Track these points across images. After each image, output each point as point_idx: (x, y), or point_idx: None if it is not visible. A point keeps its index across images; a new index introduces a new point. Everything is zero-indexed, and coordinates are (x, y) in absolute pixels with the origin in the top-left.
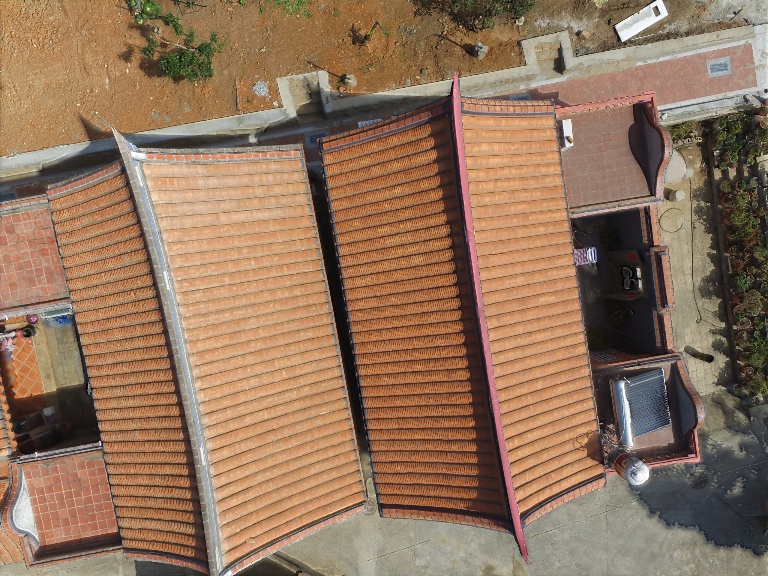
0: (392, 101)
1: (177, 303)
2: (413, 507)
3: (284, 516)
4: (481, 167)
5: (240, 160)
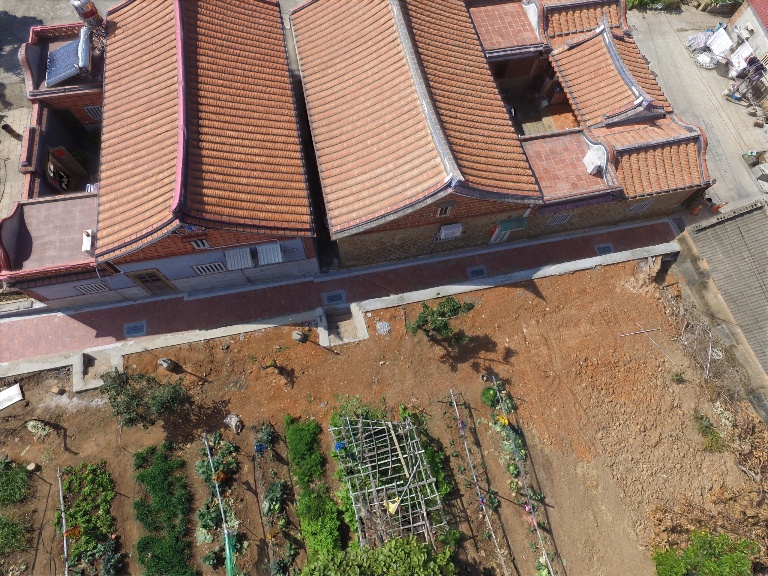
0: None
1: (419, 99)
2: None
3: None
4: None
5: None
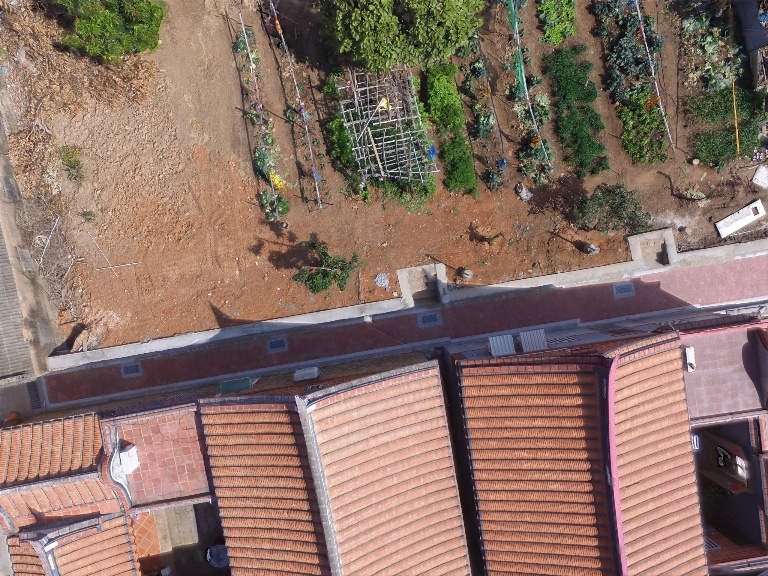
0: (505, 291)
1: (334, 532)
2: None
3: None
4: (620, 409)
5: (386, 386)
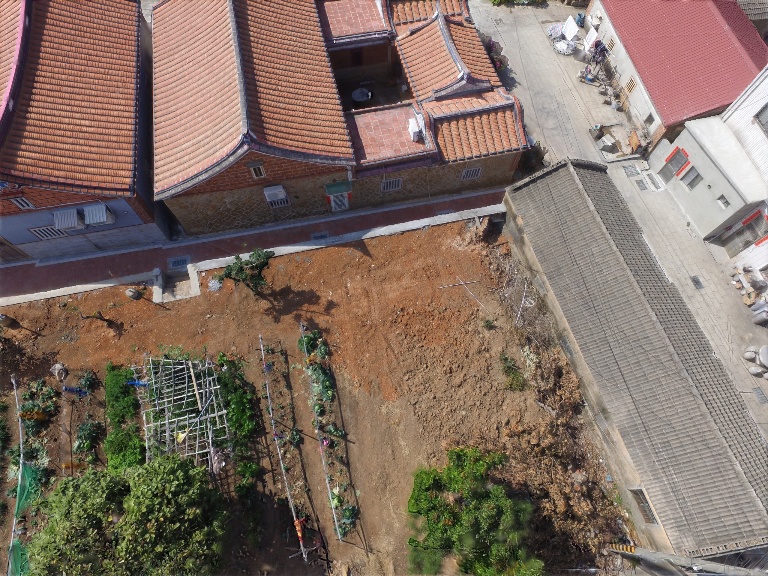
0: None
1: None
2: None
3: None
4: None
5: None
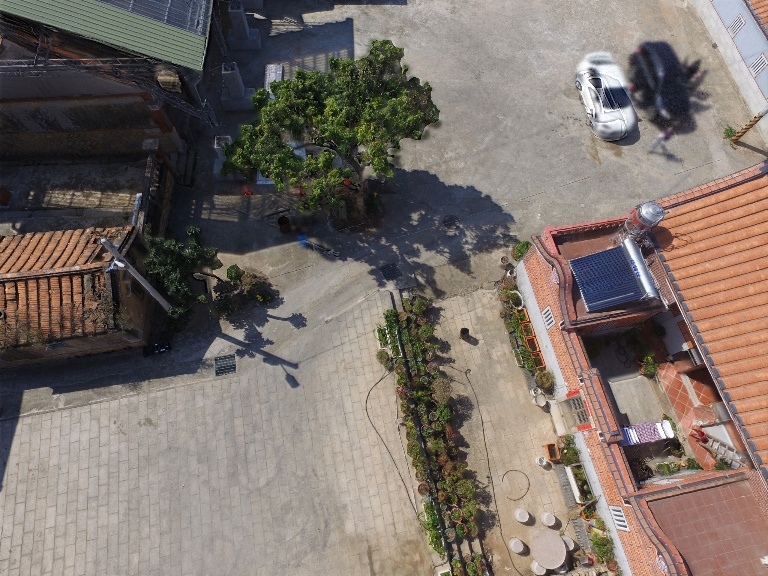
0: None
1: None
2: None
3: None
4: None
5: None
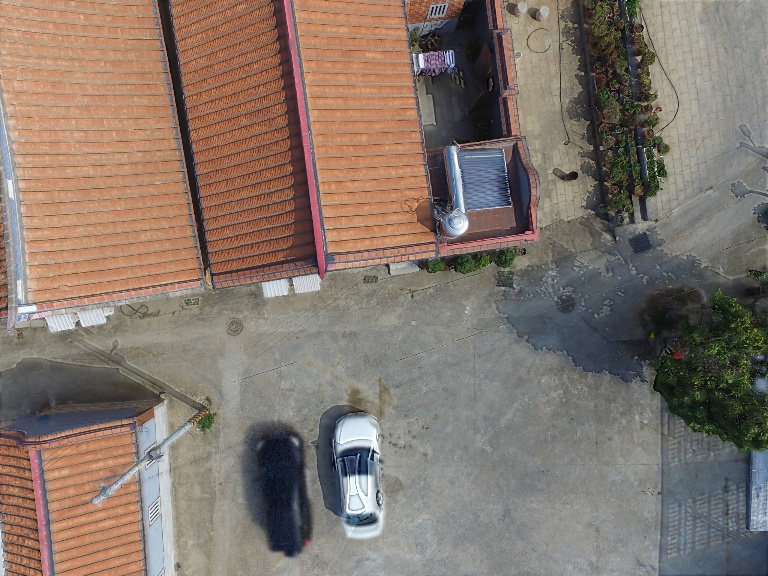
0: None
1: None
2: (240, 270)
3: (107, 274)
4: None
5: None
